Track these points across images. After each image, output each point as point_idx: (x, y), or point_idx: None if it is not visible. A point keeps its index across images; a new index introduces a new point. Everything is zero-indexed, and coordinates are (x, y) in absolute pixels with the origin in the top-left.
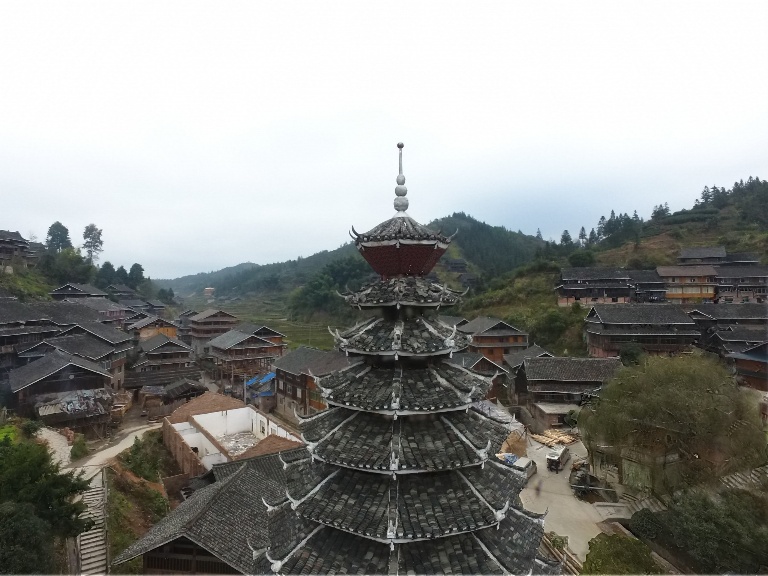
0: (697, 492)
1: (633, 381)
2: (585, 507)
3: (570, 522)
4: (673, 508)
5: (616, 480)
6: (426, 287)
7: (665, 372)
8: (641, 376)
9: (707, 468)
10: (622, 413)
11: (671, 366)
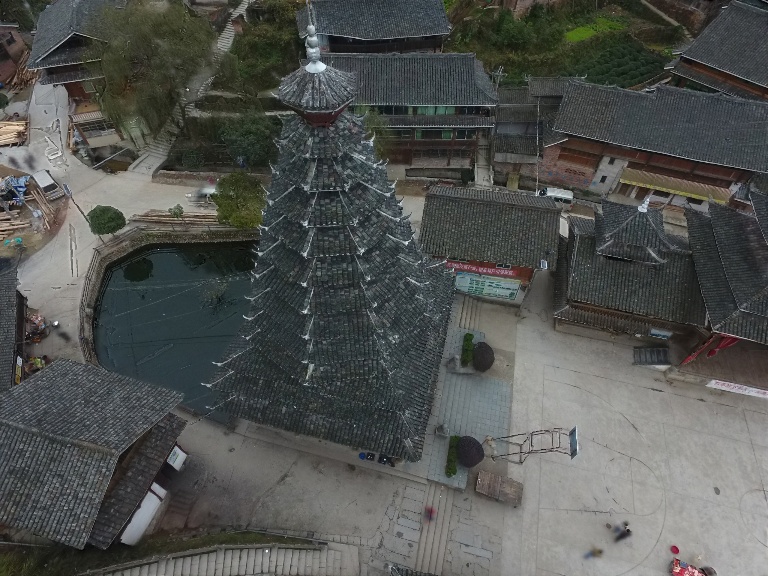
0: (227, 119)
1: (130, 48)
2: (128, 176)
3: (140, 195)
4: (230, 139)
5: (118, 139)
6: (354, 117)
7: (147, 28)
8: (132, 40)
9: (221, 99)
10: (156, 87)
11: (148, 19)
